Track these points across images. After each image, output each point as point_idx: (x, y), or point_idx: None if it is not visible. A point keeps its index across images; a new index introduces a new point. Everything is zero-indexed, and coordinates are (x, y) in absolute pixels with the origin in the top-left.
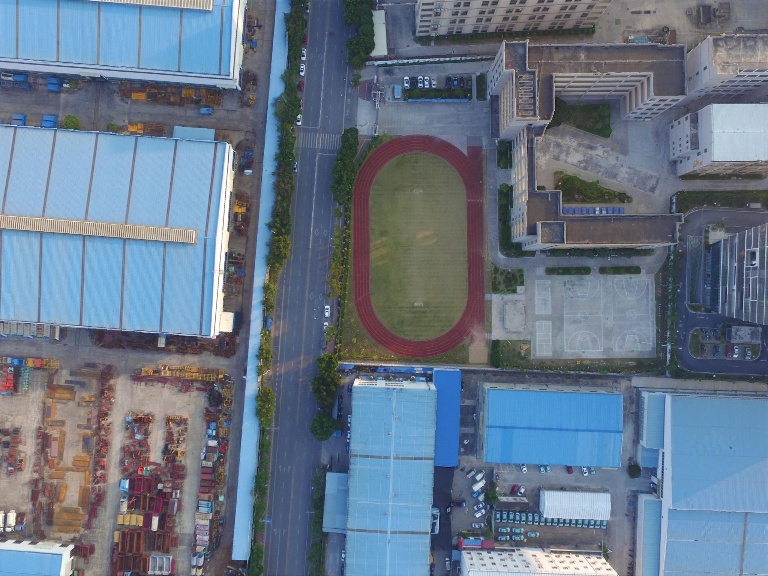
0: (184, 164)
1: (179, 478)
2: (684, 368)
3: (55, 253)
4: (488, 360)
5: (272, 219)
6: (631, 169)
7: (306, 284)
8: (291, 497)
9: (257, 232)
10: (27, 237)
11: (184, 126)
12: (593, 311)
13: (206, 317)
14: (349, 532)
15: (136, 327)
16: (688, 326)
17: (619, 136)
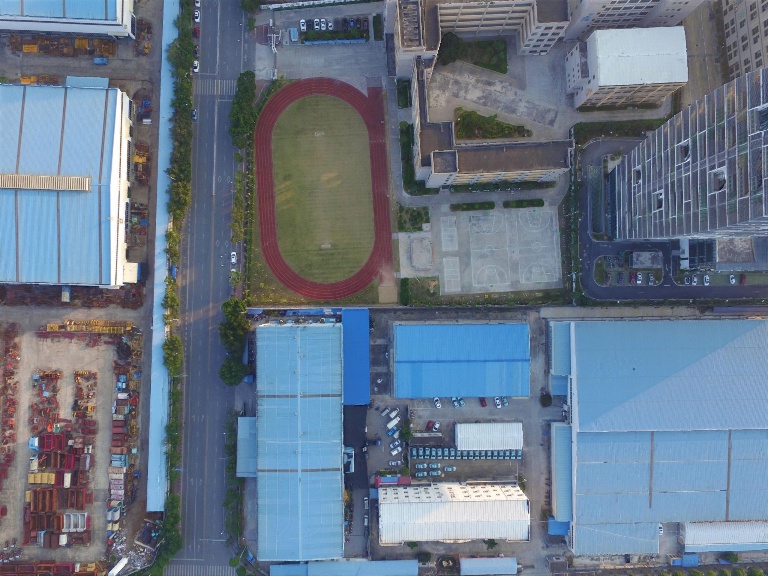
0: (75, 112)
1: (91, 433)
2: (590, 297)
3: None
4: (398, 299)
5: (171, 166)
6: (530, 103)
7: (211, 232)
8: (206, 446)
9: (157, 180)
10: None
11: None
12: (499, 245)
13: (105, 266)
14: (259, 473)
15: (33, 279)
16: (592, 255)
17: (516, 71)
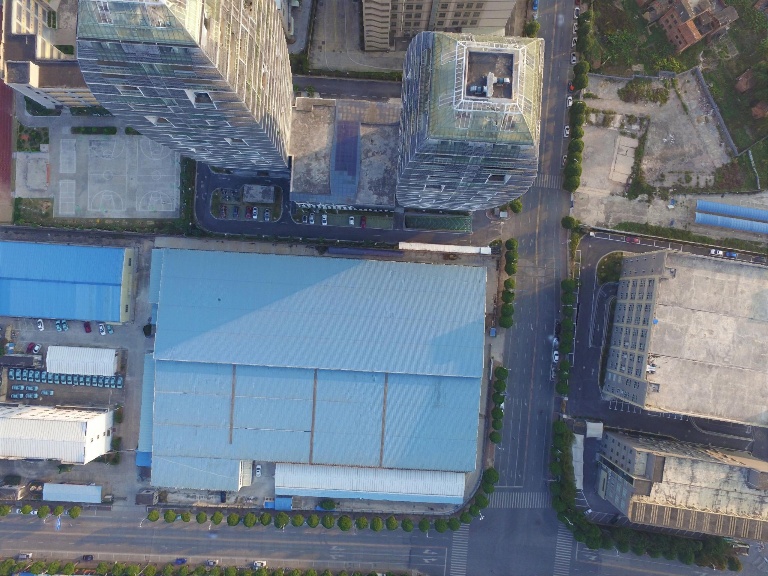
0: None
1: None
2: (205, 229)
3: None
4: (12, 218)
5: None
6: None
7: None
8: None
9: None
10: None
11: None
12: (118, 171)
13: None
14: None
15: None
16: (210, 187)
17: None
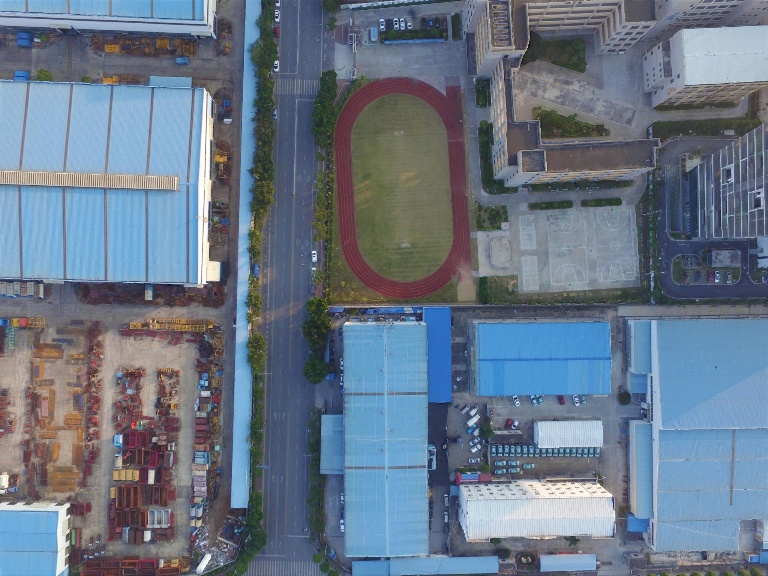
0: (162, 111)
1: (173, 431)
2: (668, 295)
3: (35, 206)
4: (476, 297)
5: (254, 165)
6: (607, 102)
7: (292, 230)
8: (287, 443)
9: (240, 179)
10: (5, 191)
11: (160, 77)
12: (577, 244)
13: (192, 264)
14: (347, 470)
15: (122, 278)
16: (670, 254)
17: (594, 70)
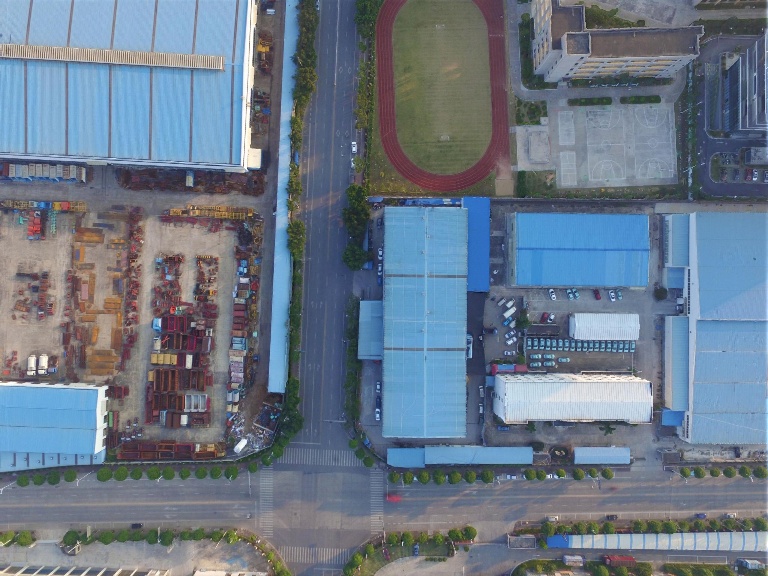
0: None
1: (212, 317)
2: (705, 193)
3: (81, 83)
4: (514, 192)
5: None
6: (648, 0)
7: (332, 121)
8: (324, 332)
9: (282, 67)
10: (52, 67)
11: None
12: (615, 140)
13: (236, 145)
14: (386, 351)
15: (165, 157)
16: (708, 152)
17: None
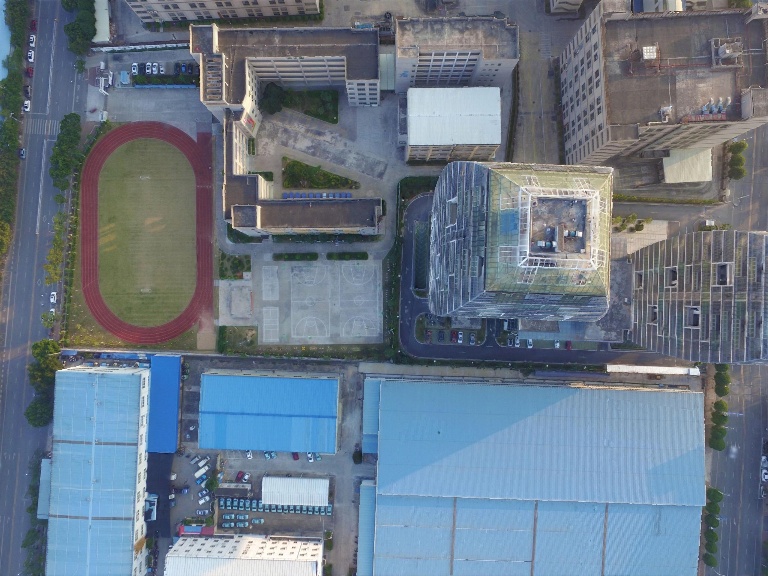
0: None
1: None
2: (410, 354)
3: None
4: (216, 346)
5: None
6: (359, 155)
7: (33, 270)
8: (16, 484)
9: None
10: None
11: None
12: (320, 297)
13: None
14: (51, 518)
15: None
16: (414, 312)
17: (347, 122)
